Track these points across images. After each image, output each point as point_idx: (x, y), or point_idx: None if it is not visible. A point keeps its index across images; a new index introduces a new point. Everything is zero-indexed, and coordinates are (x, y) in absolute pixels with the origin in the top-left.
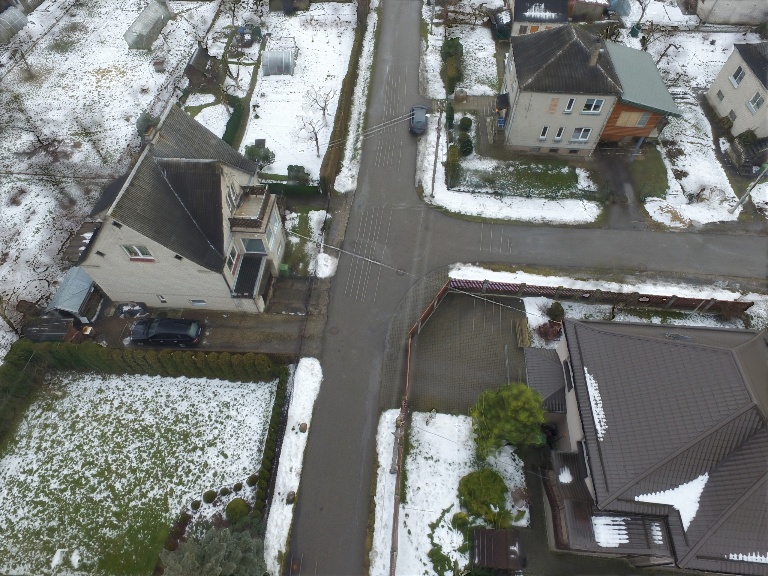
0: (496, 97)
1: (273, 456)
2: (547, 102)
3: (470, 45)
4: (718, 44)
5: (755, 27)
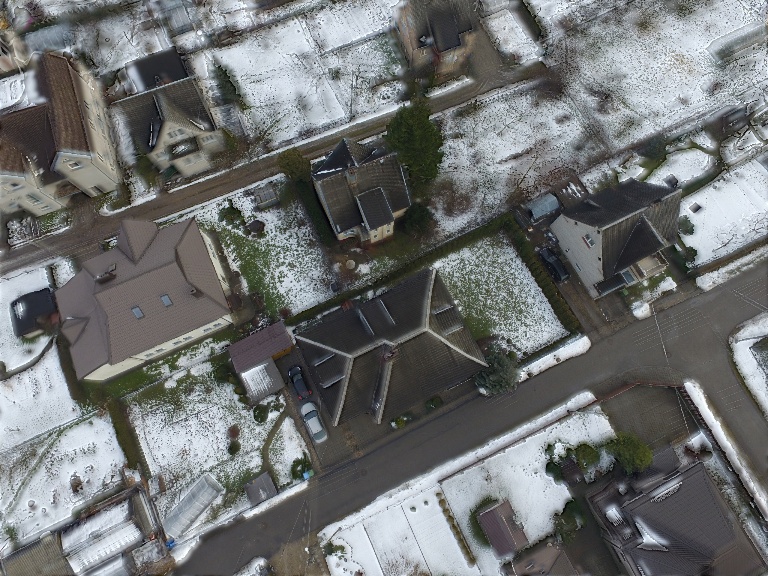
0: None
1: (540, 356)
2: None
3: None
4: None
5: None
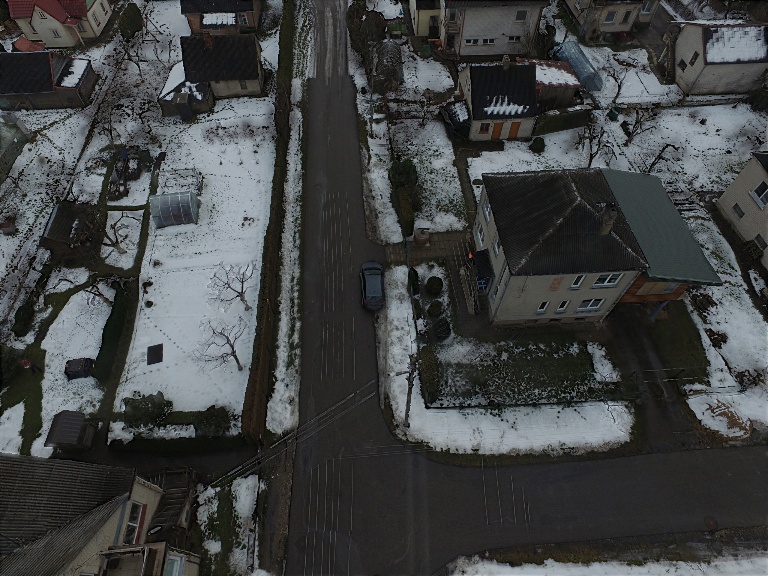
0: (466, 232)
1: None
2: (547, 282)
3: (422, 150)
4: (709, 123)
5: (743, 95)
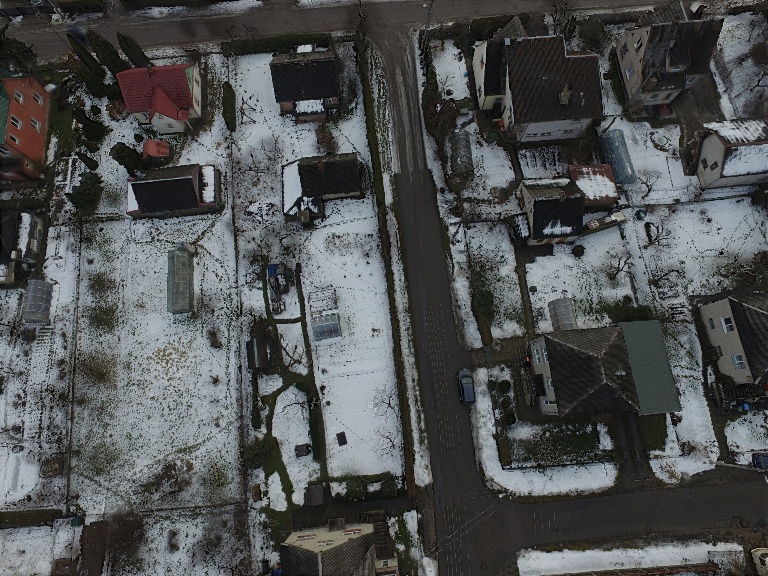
0: (525, 338)
1: None
2: None
3: (492, 256)
4: (714, 220)
5: (748, 187)
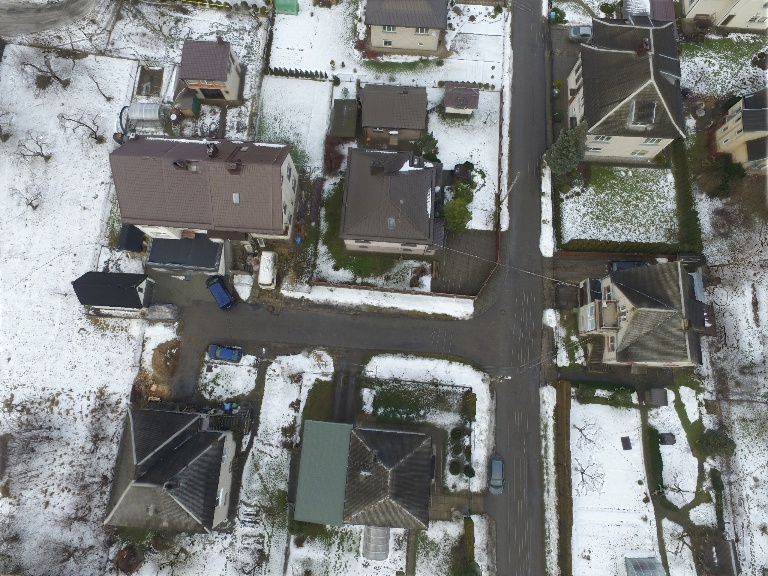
0: None
1: (555, 209)
2: None
3: None
4: None
5: None
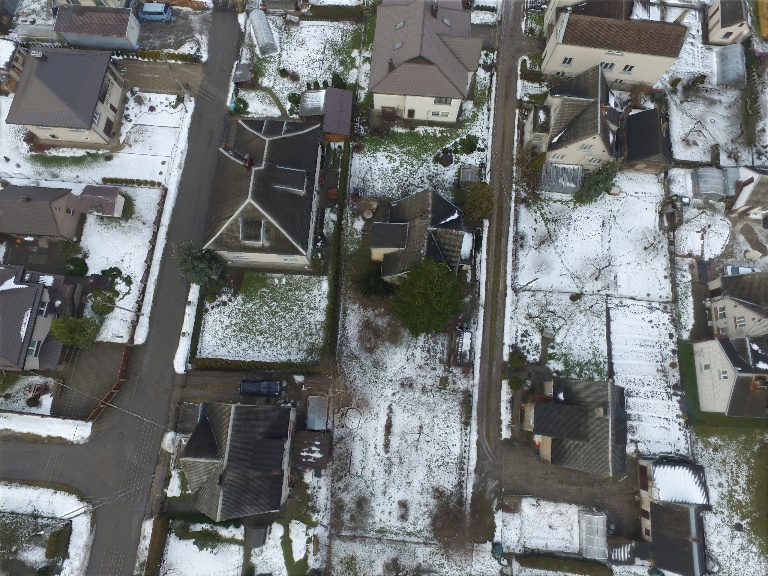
0: None
1: None
2: None
3: None
4: None
5: None
